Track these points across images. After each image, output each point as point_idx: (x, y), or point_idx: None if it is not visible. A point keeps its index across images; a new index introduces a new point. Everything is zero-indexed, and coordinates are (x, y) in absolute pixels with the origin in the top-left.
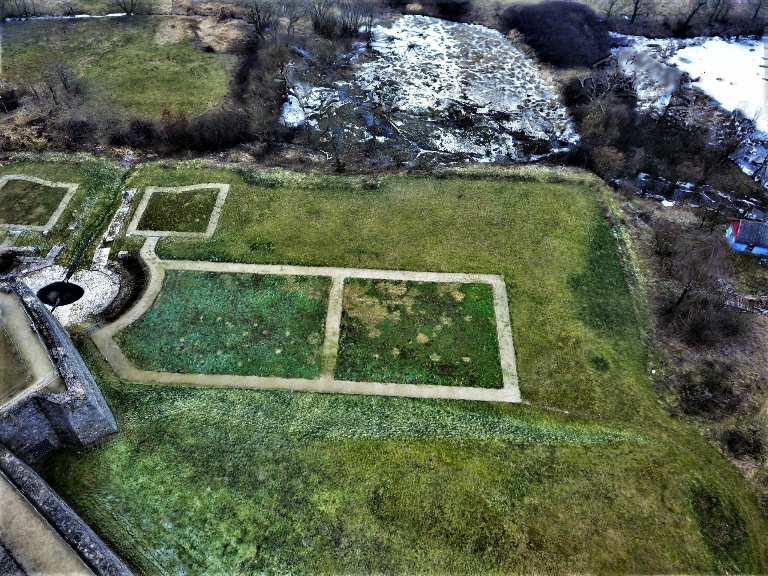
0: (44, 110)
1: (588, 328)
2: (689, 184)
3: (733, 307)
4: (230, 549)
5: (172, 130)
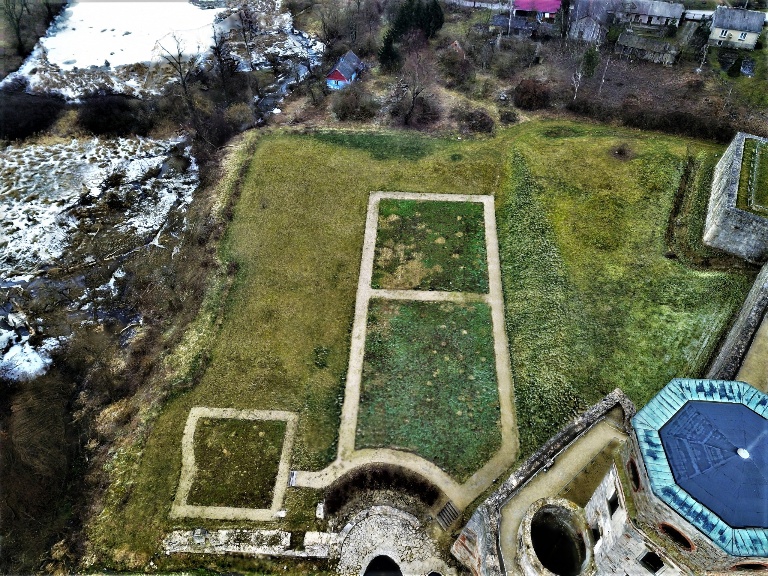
0: None
1: (425, 158)
2: (256, 97)
3: (402, 99)
4: (669, 318)
5: (32, 502)
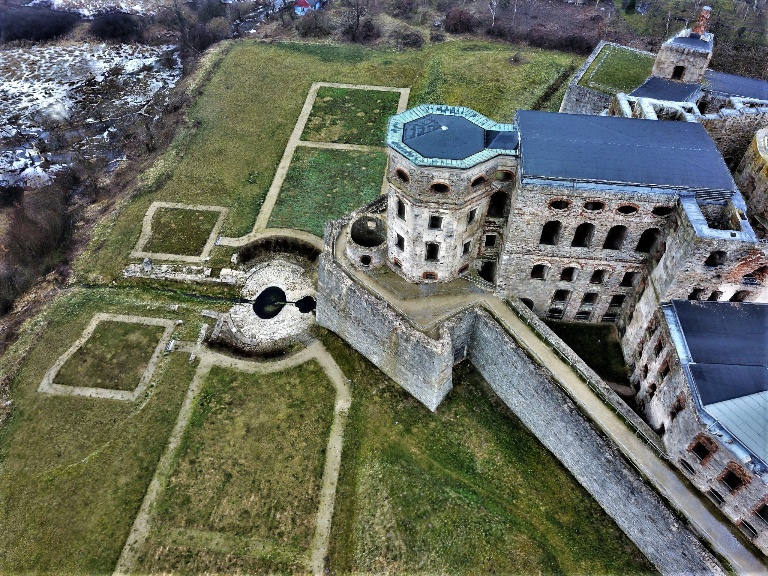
0: None
1: (362, 62)
2: (237, 21)
3: (354, 23)
4: None
5: (34, 241)
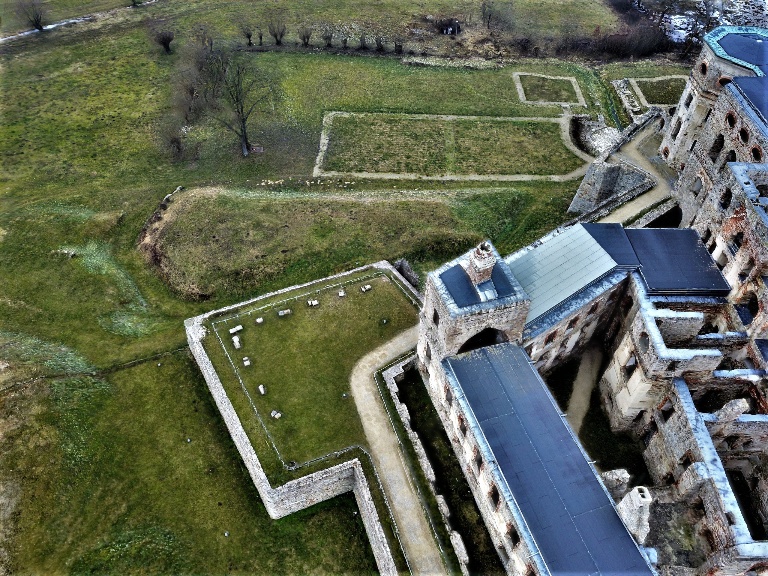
0: (483, 33)
1: None
2: None
3: None
4: None
5: (613, 41)
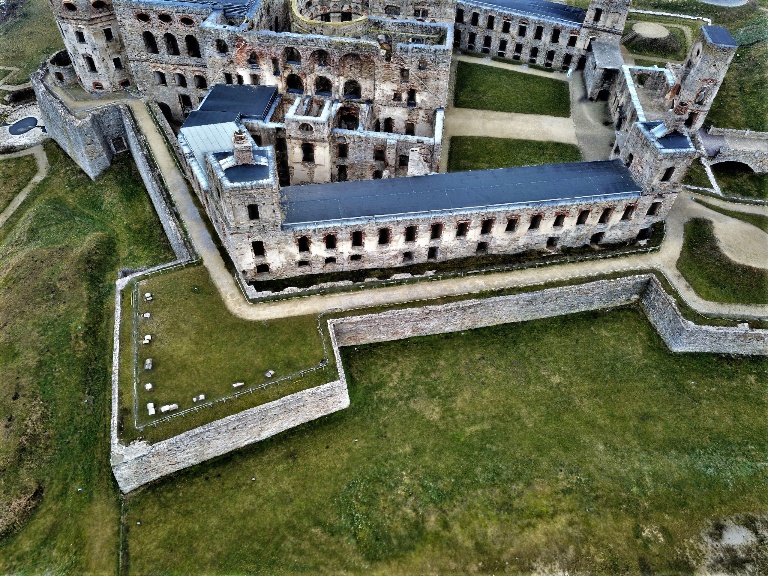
0: None
1: None
2: None
3: None
4: None
5: None
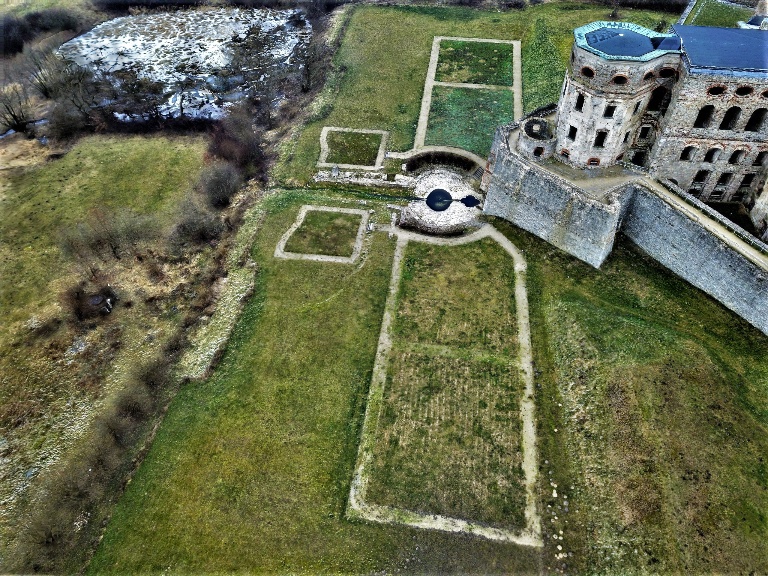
0: None
1: (474, 20)
2: None
3: None
4: None
5: (238, 154)
